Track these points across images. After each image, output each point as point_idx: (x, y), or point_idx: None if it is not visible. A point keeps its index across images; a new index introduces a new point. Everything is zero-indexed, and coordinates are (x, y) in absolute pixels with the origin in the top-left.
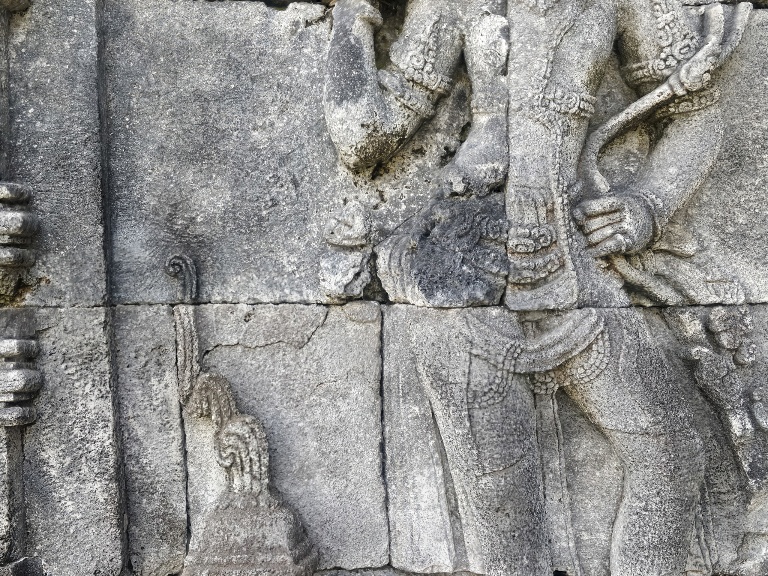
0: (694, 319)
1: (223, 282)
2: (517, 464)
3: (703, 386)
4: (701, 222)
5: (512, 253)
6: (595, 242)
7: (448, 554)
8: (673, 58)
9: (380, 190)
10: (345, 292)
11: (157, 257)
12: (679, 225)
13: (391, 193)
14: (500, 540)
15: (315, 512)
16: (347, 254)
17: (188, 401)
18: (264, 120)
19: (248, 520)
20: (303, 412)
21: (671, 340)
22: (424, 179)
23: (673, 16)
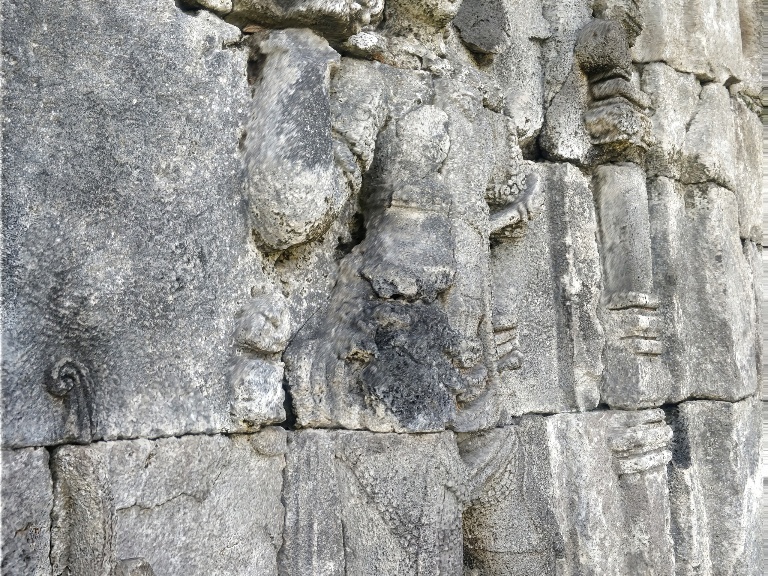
0: None
1: (121, 405)
2: None
3: None
4: None
5: None
6: None
7: None
8: (517, 187)
9: (283, 280)
10: None
11: (33, 362)
12: None
13: (294, 286)
14: None
15: None
16: None
17: None
18: (169, 161)
19: None
20: None
21: None
22: (322, 272)
23: None
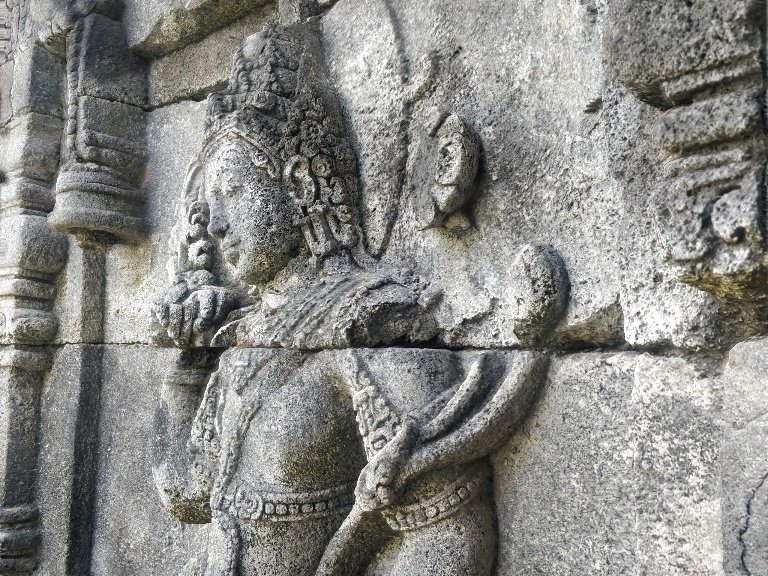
0: None
1: None
2: None
3: None
4: None
5: None
6: None
7: None
8: (371, 453)
9: None
10: None
11: (110, 574)
12: None
13: None
14: None
15: None
16: None
17: None
18: None
19: None
20: None
21: None
22: None
23: (365, 395)
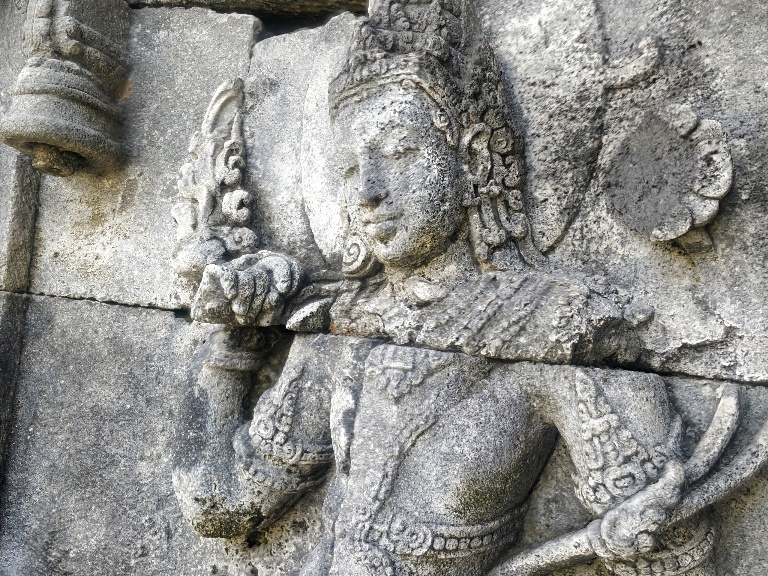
0: None
1: None
2: None
3: None
4: None
5: None
6: None
7: None
8: (605, 489)
9: (253, 564)
10: None
11: None
12: None
13: (263, 572)
14: None
15: None
16: None
17: None
18: (152, 450)
19: None
20: None
21: None
22: (301, 564)
23: (606, 424)
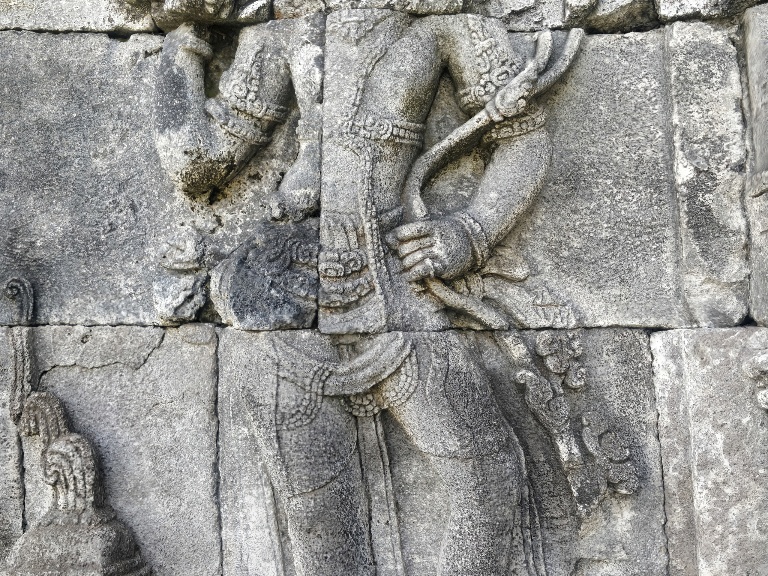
0: (518, 343)
1: (61, 304)
2: (328, 486)
3: (532, 410)
4: (535, 246)
5: (324, 277)
6: (408, 266)
7: (276, 574)
8: (492, 84)
9: (217, 215)
10: (176, 314)
11: None
12: (510, 249)
13: (227, 218)
14: (313, 561)
15: (149, 530)
16: (181, 277)
17: (19, 420)
18: (105, 147)
19: (65, 537)
20: (139, 432)
21: (504, 364)
22: (260, 204)
23: (490, 43)
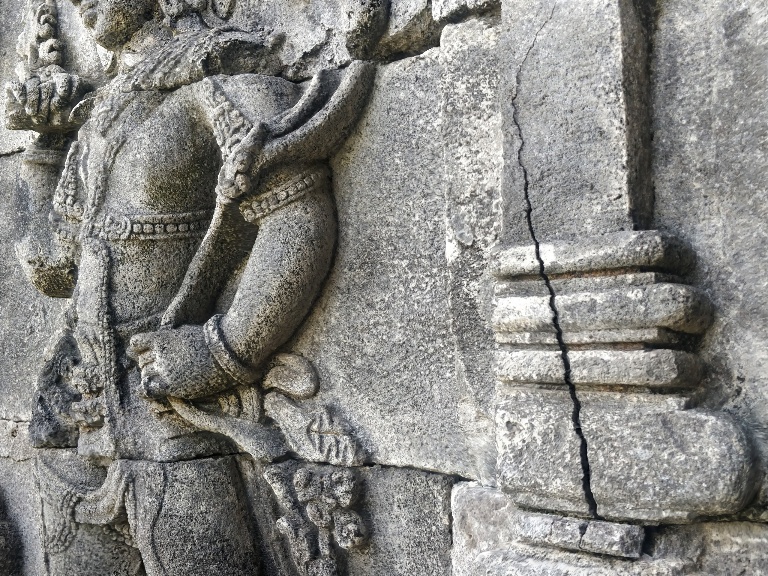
0: (274, 481)
1: (1, 401)
2: None
3: None
4: (328, 352)
5: (83, 393)
6: None
7: None
8: None
9: None
10: None
11: None
12: (292, 357)
13: None
14: None
15: None
16: None
17: None
18: None
19: None
20: None
21: None
22: None
23: (221, 109)
